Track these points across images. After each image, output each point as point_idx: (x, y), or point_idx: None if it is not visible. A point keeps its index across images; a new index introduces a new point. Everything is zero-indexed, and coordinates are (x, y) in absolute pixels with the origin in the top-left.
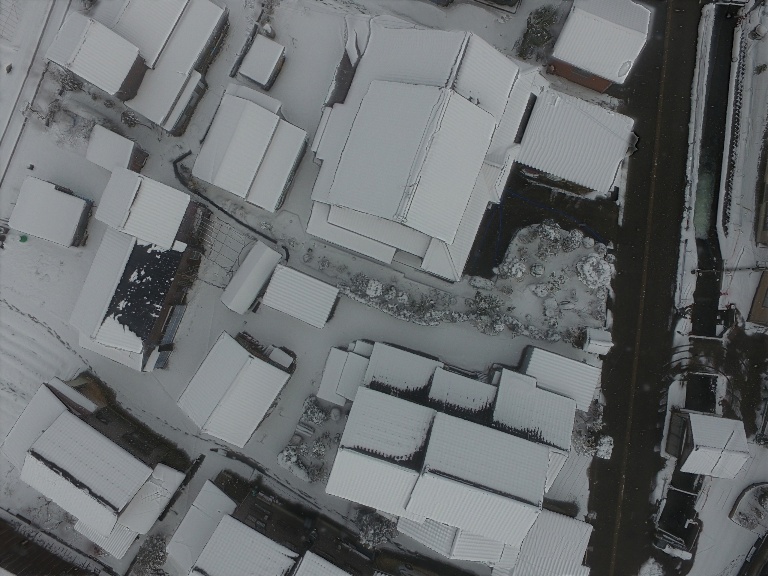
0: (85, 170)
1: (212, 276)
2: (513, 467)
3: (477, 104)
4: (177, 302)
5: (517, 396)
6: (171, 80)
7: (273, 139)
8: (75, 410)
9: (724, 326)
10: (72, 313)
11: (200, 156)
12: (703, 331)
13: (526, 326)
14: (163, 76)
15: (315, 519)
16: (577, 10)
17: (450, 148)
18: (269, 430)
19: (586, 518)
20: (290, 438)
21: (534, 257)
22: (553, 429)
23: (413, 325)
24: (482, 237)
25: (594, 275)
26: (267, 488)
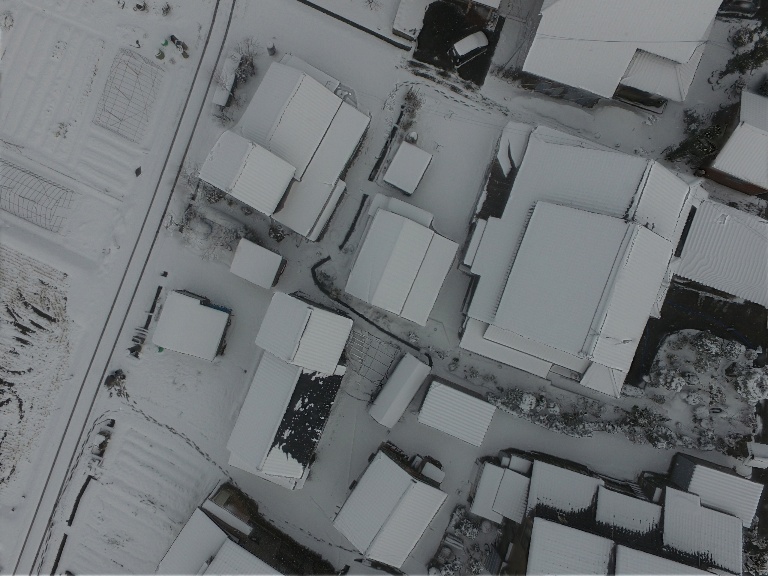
0: (222, 278)
1: (354, 385)
2: None
3: (652, 229)
4: None
5: (683, 516)
6: (318, 191)
7: (427, 254)
8: (232, 535)
9: None
10: (230, 438)
11: (353, 272)
12: None
13: (678, 435)
14: (310, 188)
15: None
16: (745, 125)
17: (633, 280)
18: None
19: None
20: (436, 548)
21: (683, 363)
22: (723, 551)
23: None
24: None
25: (758, 391)
26: None
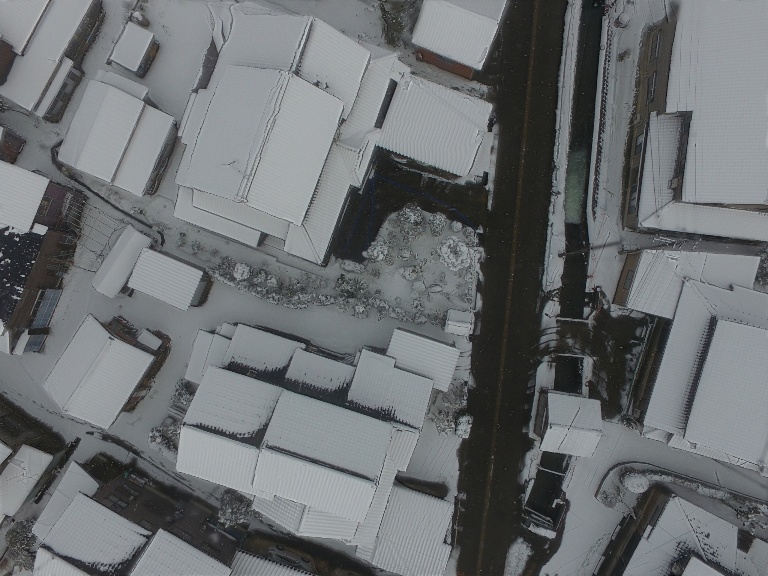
0: None
1: (88, 261)
2: (354, 443)
3: (326, 88)
4: (48, 286)
5: (374, 376)
6: (41, 67)
7: (139, 124)
8: None
9: (591, 308)
10: None
11: (66, 141)
12: (570, 313)
13: (394, 309)
14: (33, 63)
15: (188, 501)
16: None
17: (293, 130)
18: (144, 413)
19: (456, 498)
20: None
21: None
22: (407, 408)
23: (285, 308)
24: (354, 222)
25: (452, 257)
26: (141, 470)
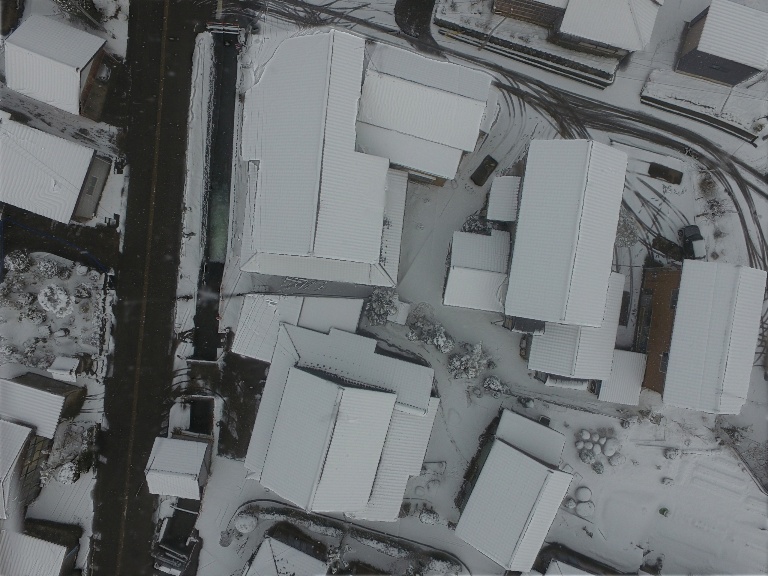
0: None
1: None
2: None
3: None
4: None
5: None
6: None
7: None
8: None
9: (223, 349)
10: None
11: None
12: (200, 354)
13: None
14: None
15: None
16: (8, 44)
17: None
18: None
19: (91, 539)
20: None
21: (32, 285)
22: None
23: None
24: None
25: (49, 305)
26: None
